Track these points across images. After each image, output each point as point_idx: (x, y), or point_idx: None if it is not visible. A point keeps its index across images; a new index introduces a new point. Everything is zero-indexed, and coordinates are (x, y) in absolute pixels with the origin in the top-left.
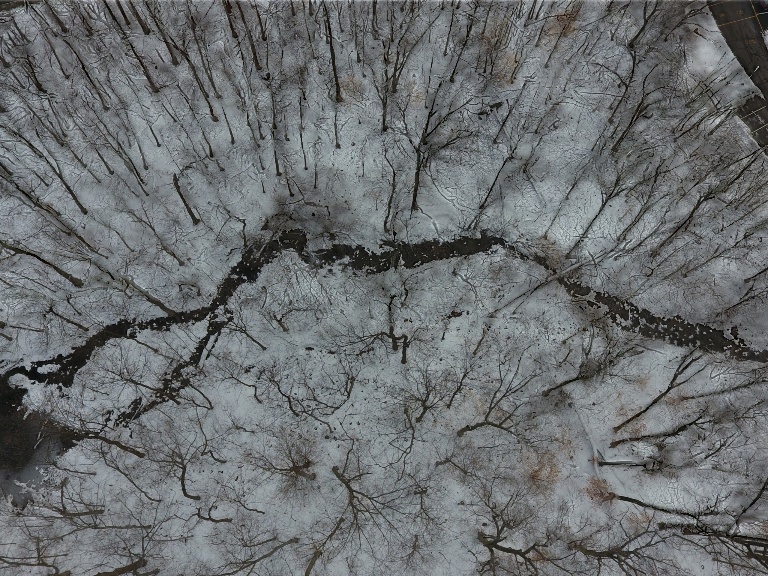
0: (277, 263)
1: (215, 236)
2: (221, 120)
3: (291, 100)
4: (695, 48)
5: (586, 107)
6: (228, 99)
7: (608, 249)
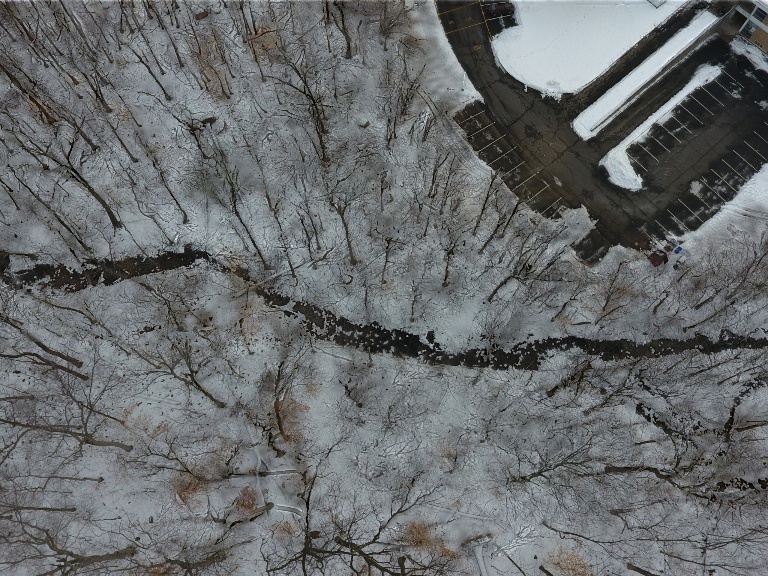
0: None
1: None
2: None
3: None
4: (417, 56)
5: (300, 119)
6: None
7: (308, 258)
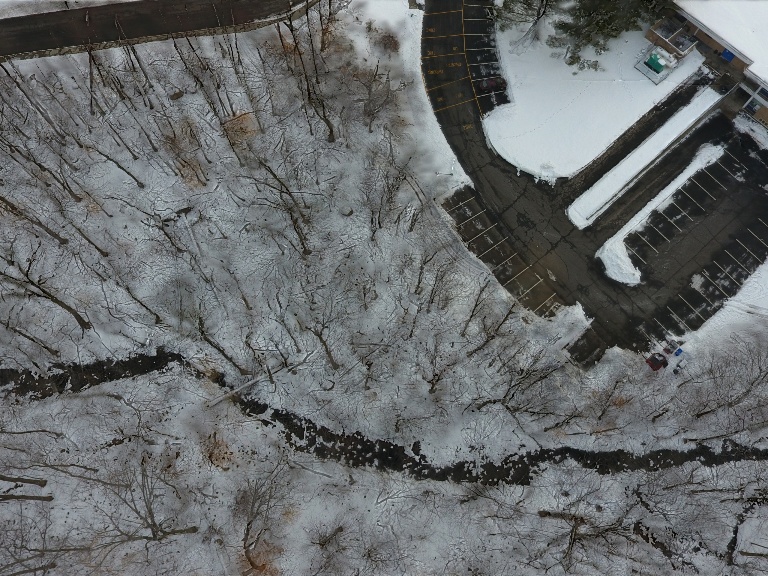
0: None
1: None
2: None
3: None
4: (404, 138)
5: (280, 208)
6: None
7: (287, 363)
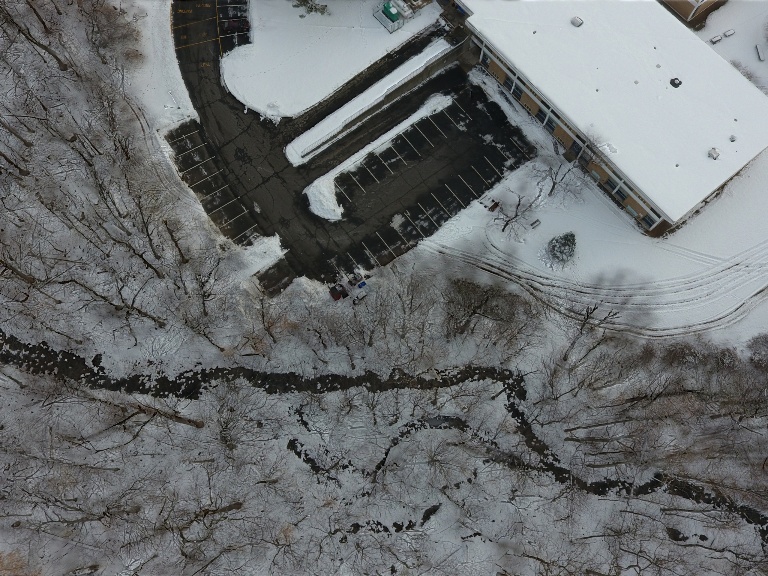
0: None
1: None
2: None
3: None
4: (139, 71)
5: (5, 130)
6: None
7: None
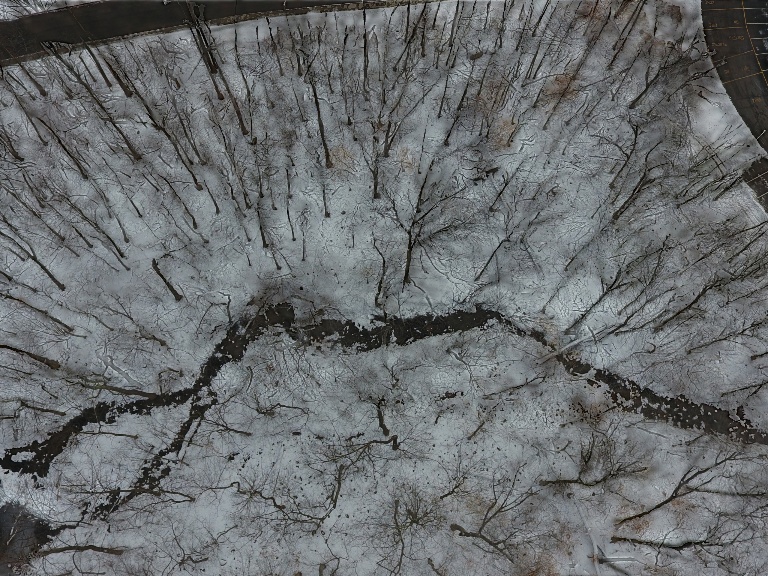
0: (263, 340)
1: (195, 329)
2: (205, 189)
3: (278, 167)
4: (699, 108)
5: (586, 172)
6: (213, 166)
7: (609, 324)
